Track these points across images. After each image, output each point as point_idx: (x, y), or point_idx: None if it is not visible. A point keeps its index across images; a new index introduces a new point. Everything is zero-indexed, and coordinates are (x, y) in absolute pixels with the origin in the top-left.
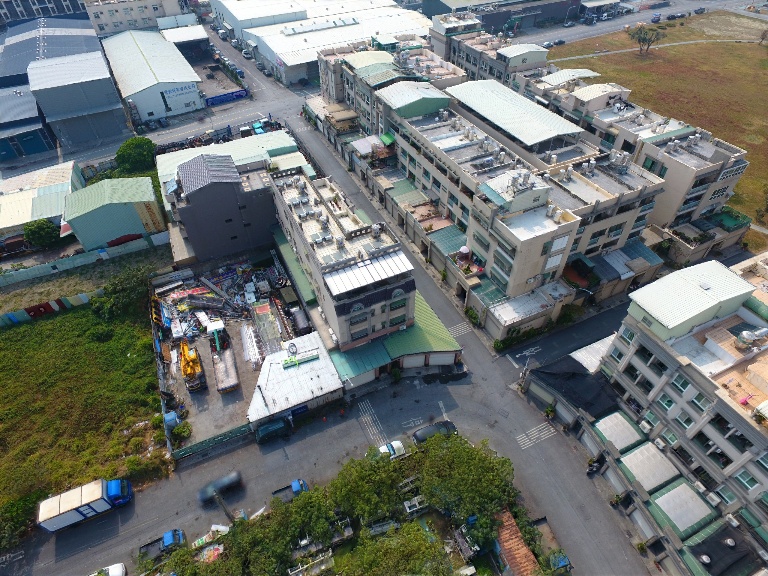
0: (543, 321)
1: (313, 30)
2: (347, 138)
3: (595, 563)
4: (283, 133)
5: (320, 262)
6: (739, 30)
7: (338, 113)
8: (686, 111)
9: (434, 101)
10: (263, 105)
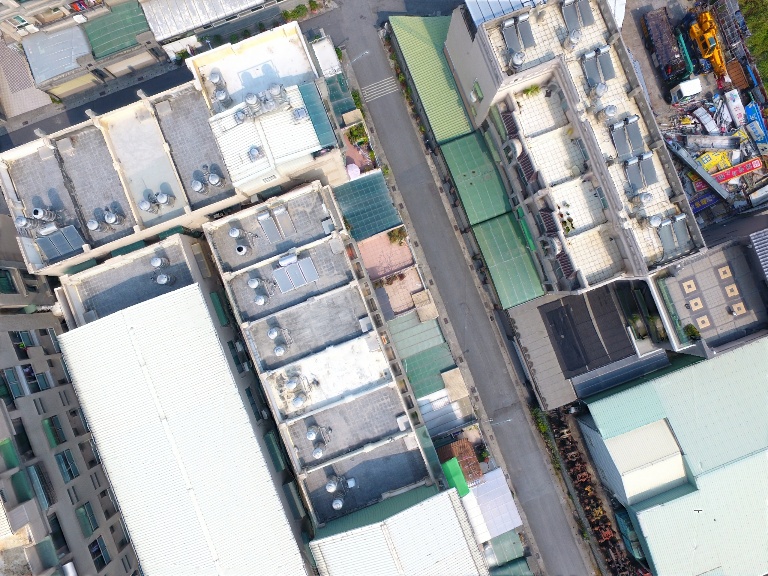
0: None
1: None
2: None
3: None
4: None
5: None
6: None
7: None
8: None
9: None
10: None
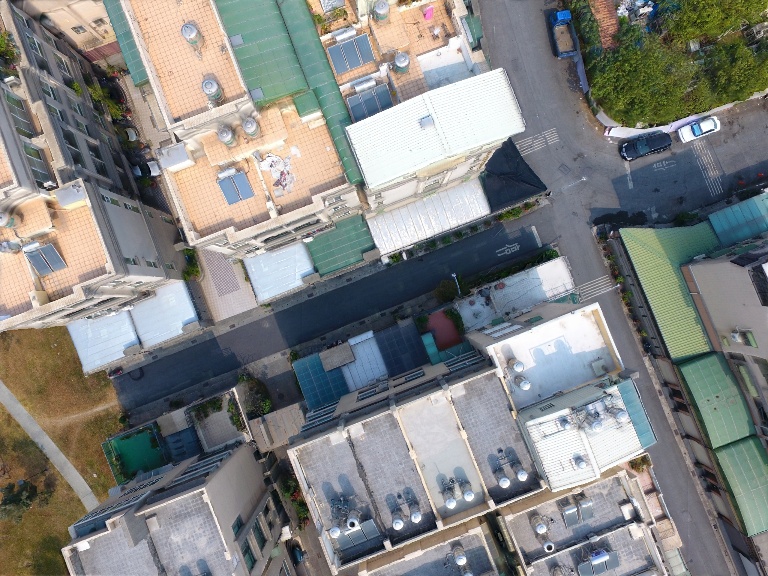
0: None
1: None
2: None
3: (523, 25)
4: None
5: None
6: None
7: None
8: None
9: None
10: None
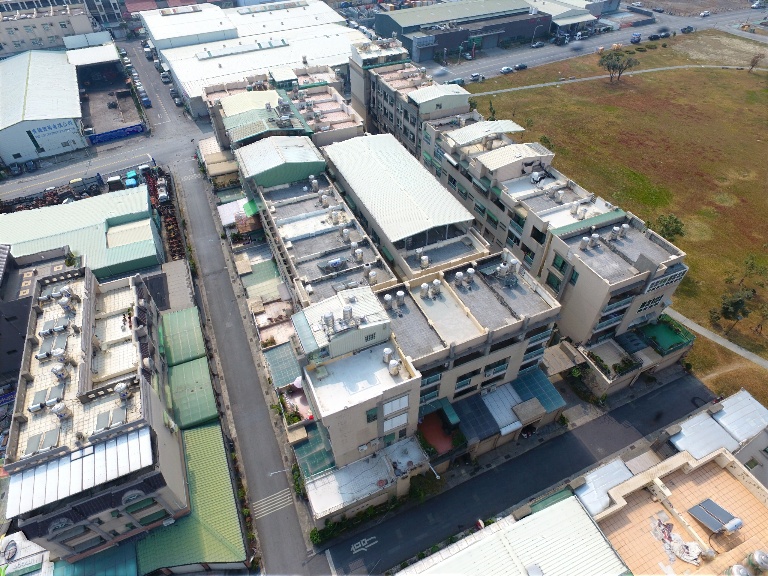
0: (387, 496)
1: (233, 53)
2: (224, 196)
3: None
4: (144, 191)
5: (7, 457)
6: (728, 53)
7: (216, 165)
8: (650, 159)
9: (302, 166)
10: (157, 144)
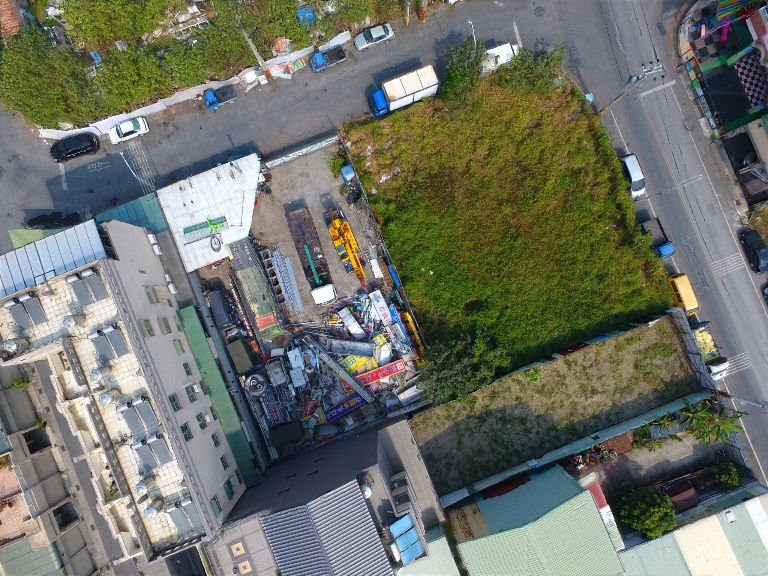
0: None
1: None
2: None
3: None
4: None
5: (101, 270)
6: None
7: None
8: None
9: None
10: None
